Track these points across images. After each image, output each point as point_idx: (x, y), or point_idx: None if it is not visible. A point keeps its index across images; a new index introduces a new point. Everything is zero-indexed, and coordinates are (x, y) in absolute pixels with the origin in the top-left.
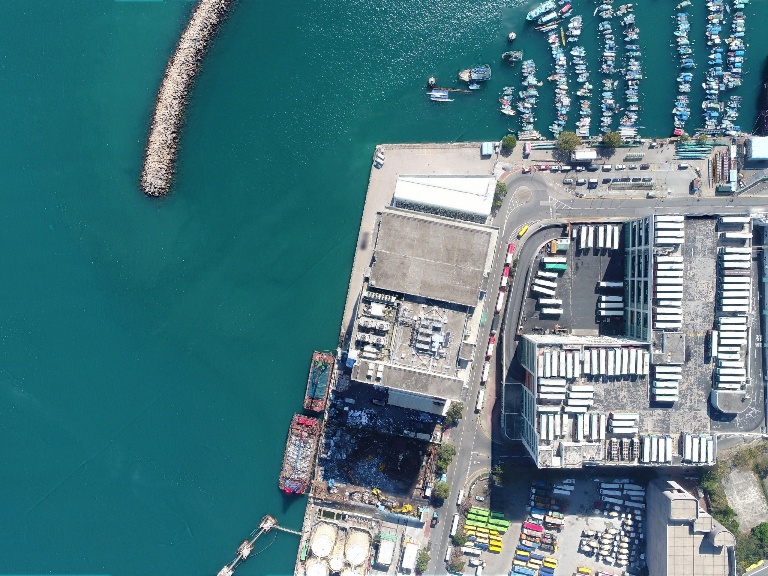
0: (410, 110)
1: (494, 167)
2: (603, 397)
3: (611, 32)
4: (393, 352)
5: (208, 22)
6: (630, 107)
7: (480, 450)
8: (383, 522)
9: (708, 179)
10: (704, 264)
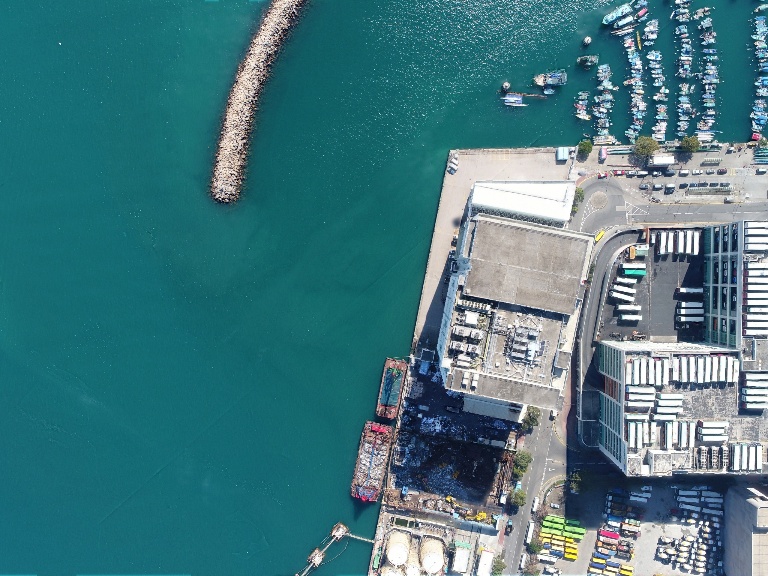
0: (484, 115)
1: (569, 172)
2: (691, 405)
3: (688, 36)
4: (487, 361)
5: (279, 27)
6: (707, 111)
7: (555, 457)
8: (456, 530)
9: None
10: None
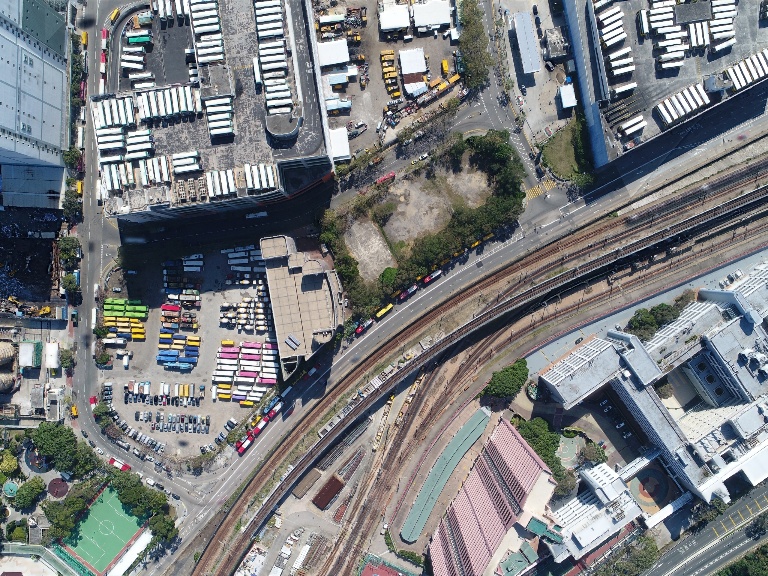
0: None
1: None
2: (166, 142)
3: None
4: None
5: None
6: None
7: (109, 242)
8: (26, 329)
9: None
10: None
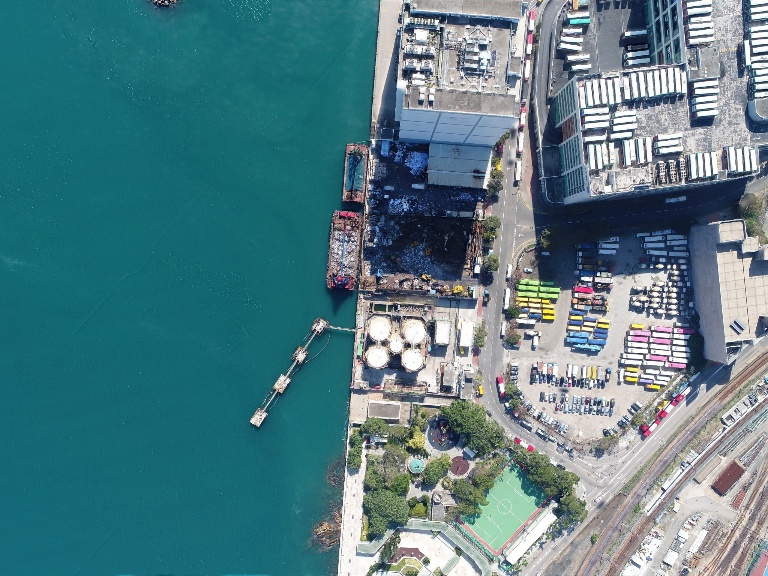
0: None
1: None
2: (645, 123)
3: None
4: (442, 77)
5: None
6: None
7: (523, 222)
8: (435, 308)
9: None
10: None
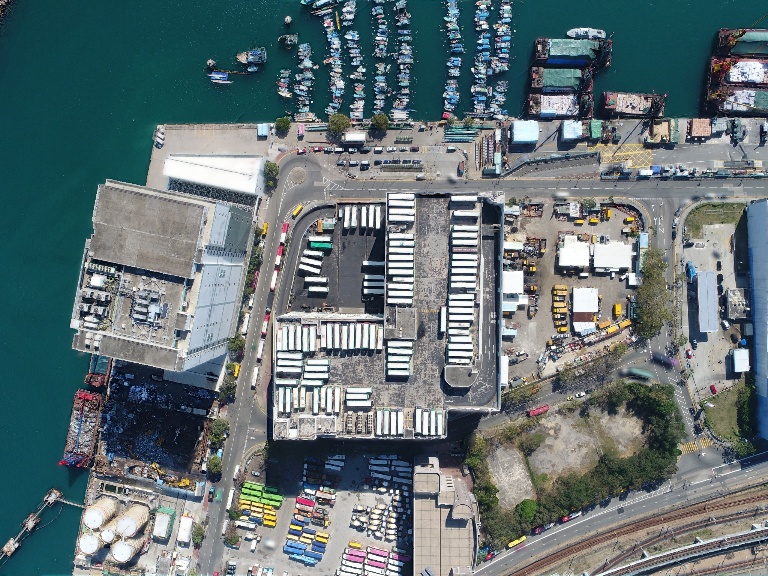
0: (191, 91)
1: (270, 148)
2: (341, 371)
3: (384, 17)
4: (114, 322)
5: None
6: (401, 90)
7: (256, 426)
8: (163, 496)
9: (475, 162)
10: (437, 242)
